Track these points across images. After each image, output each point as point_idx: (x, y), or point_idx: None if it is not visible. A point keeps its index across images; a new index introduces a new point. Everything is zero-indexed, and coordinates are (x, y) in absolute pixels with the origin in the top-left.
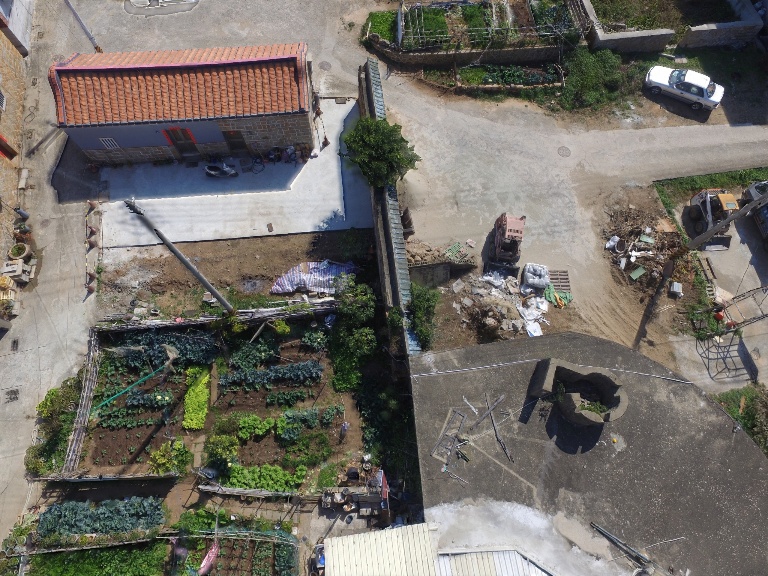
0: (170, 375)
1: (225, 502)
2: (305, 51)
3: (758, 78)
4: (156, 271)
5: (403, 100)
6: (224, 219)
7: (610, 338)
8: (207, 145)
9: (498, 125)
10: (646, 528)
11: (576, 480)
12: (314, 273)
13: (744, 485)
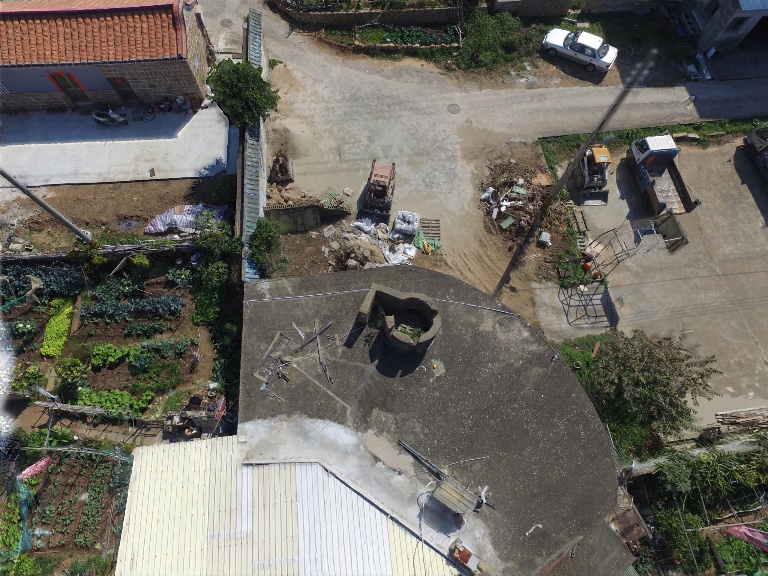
0: (34, 305)
1: (73, 424)
2: (190, 2)
3: (658, 43)
4: (35, 210)
5: (301, 57)
6: (109, 164)
7: (473, 283)
8: (96, 93)
9: (392, 82)
10: (452, 447)
11: (391, 401)
12: (187, 214)
13: (554, 410)
